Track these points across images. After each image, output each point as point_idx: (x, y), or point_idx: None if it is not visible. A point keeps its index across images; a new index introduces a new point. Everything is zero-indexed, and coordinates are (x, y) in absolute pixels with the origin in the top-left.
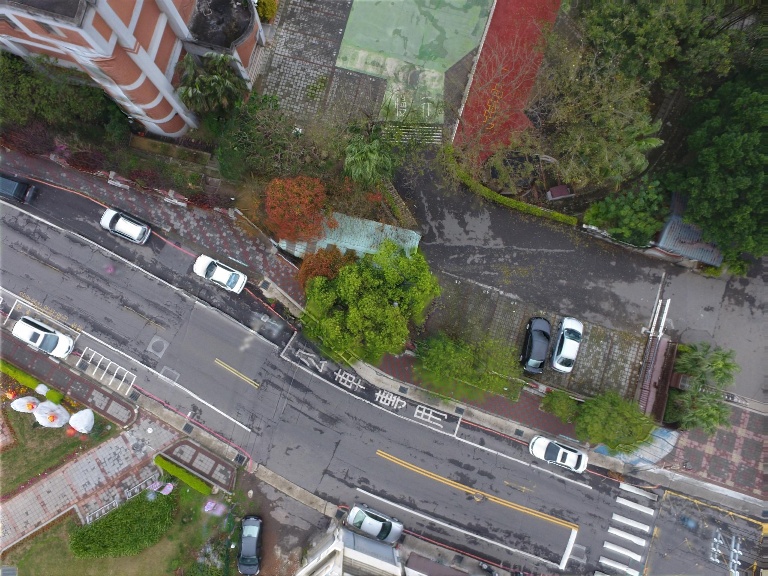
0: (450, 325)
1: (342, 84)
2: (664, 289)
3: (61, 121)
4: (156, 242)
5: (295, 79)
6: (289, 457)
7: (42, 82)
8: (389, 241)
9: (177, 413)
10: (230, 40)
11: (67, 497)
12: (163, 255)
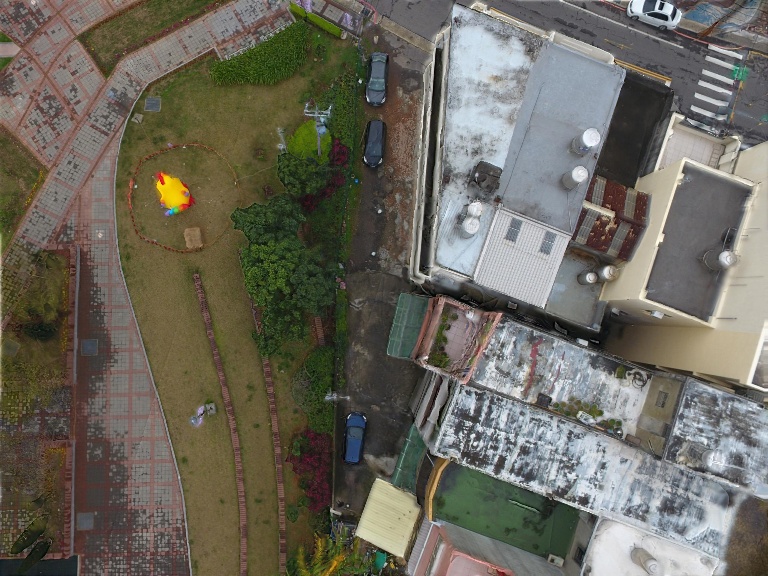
0: None
1: None
2: None
3: None
4: None
5: None
6: (411, 11)
7: None
8: None
9: None
10: None
11: (207, 41)
12: None
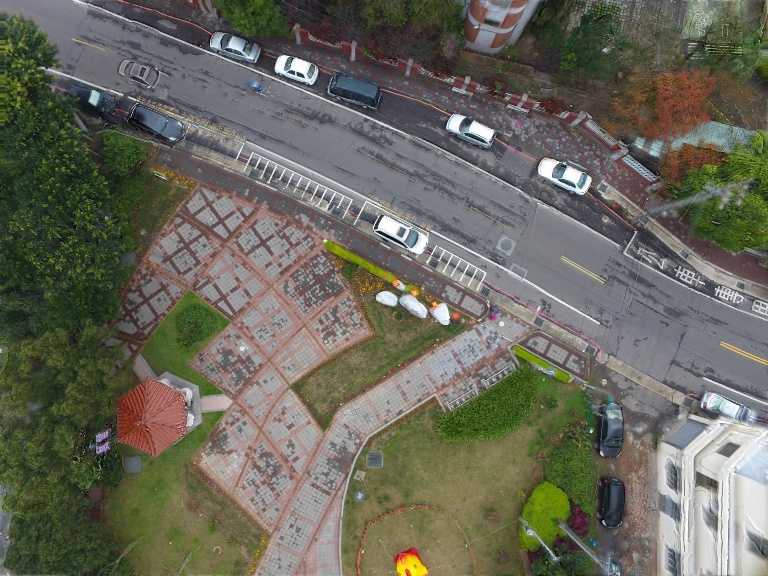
0: None
1: (645, 6)
2: None
3: None
4: (498, 147)
5: (600, 1)
6: (637, 348)
7: None
8: (738, 141)
9: (527, 307)
10: None
11: (426, 387)
12: (505, 159)
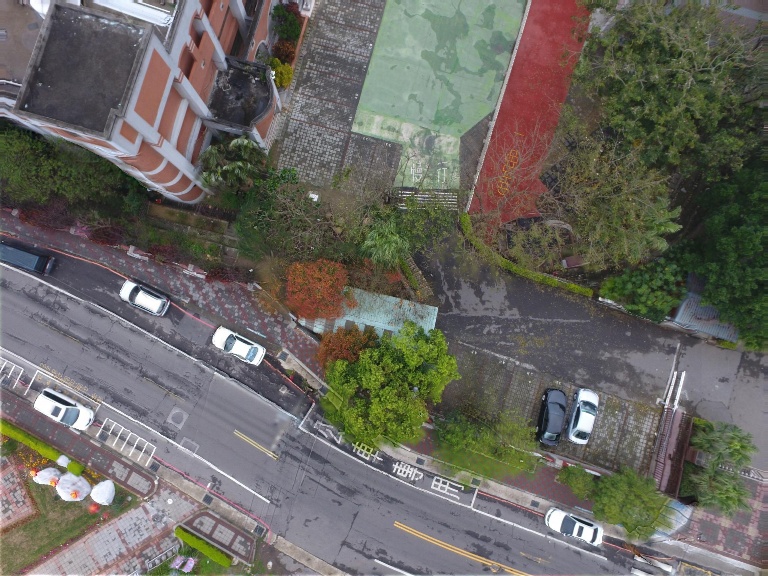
0: (466, 395)
1: (358, 150)
2: (679, 360)
3: (82, 199)
4: (175, 313)
5: (311, 144)
6: (308, 528)
7: (64, 164)
8: (407, 317)
9: (197, 484)
10: (249, 118)
11: (88, 568)
12: (182, 326)
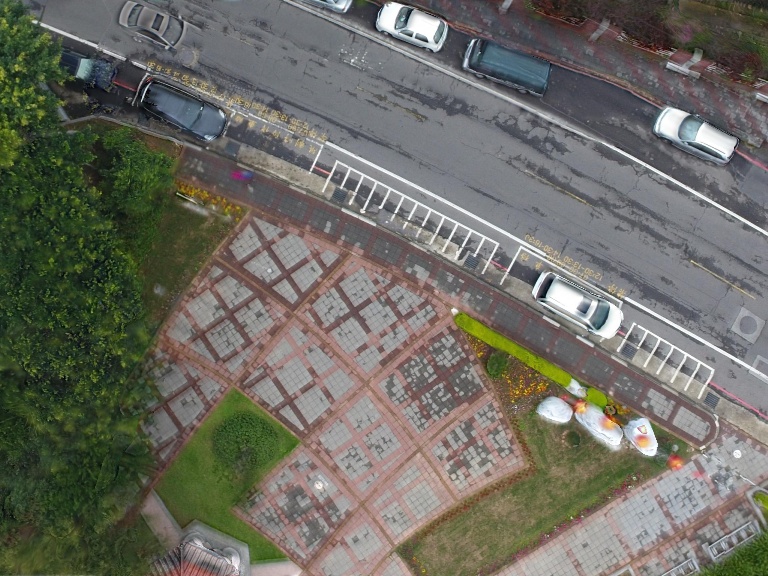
0: None
1: None
2: None
3: None
4: (737, 163)
5: None
6: None
7: None
8: None
9: None
10: None
11: (614, 553)
12: (749, 183)
